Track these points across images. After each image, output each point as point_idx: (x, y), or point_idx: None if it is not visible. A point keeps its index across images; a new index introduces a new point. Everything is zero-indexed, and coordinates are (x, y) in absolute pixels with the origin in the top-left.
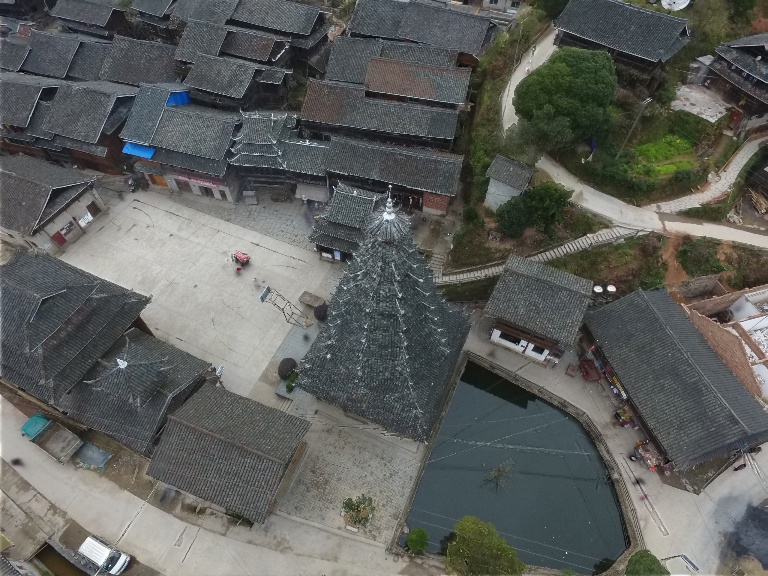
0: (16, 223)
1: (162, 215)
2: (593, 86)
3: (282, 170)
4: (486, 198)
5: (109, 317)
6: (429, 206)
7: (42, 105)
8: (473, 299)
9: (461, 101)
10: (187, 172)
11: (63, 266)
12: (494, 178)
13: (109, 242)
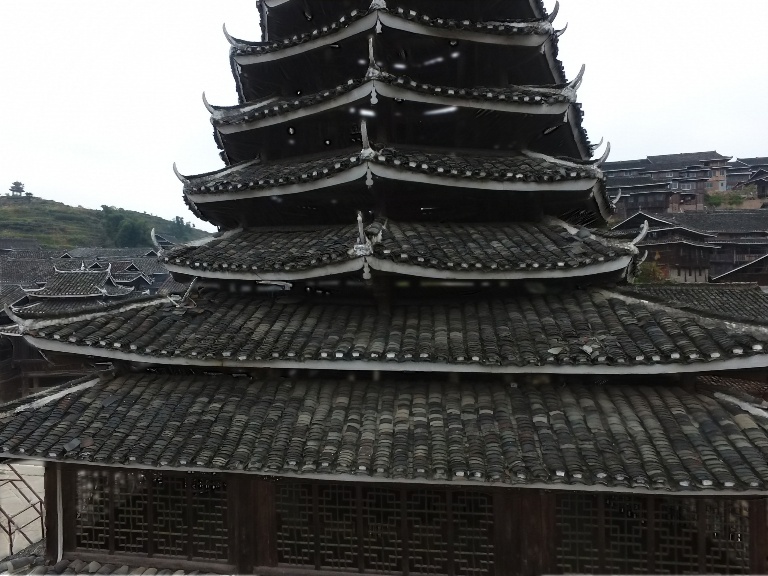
0: None
1: None
2: None
3: None
4: None
5: None
6: None
7: None
8: None
9: None
10: None
11: None
12: None
13: None
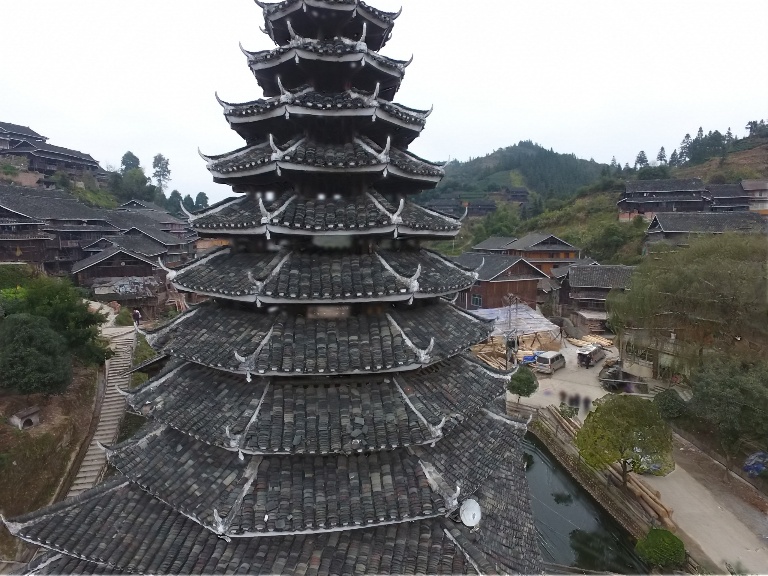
0: None
1: None
2: None
3: None
4: None
5: None
6: None
7: None
8: None
9: None
10: None
11: None
12: None
13: None
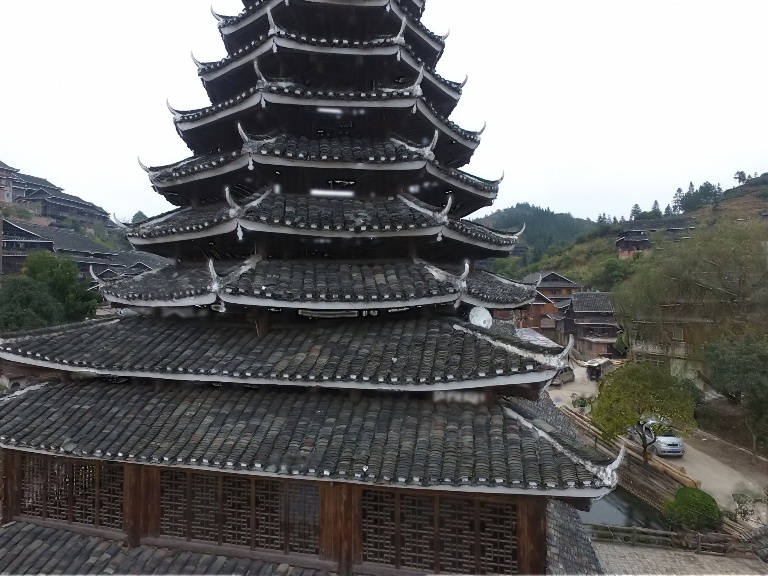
0: None
1: None
2: None
3: None
4: None
5: None
6: None
7: None
8: None
9: None
10: None
11: None
12: None
13: None
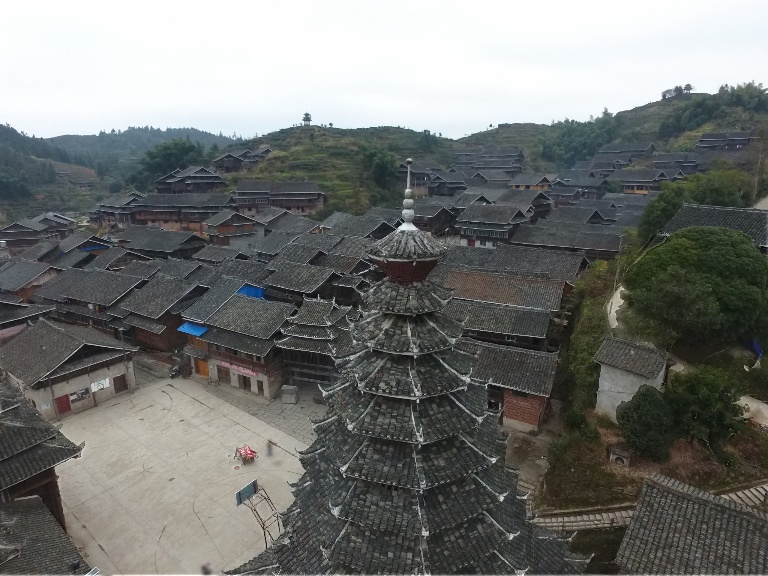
0: (29, 373)
1: (186, 401)
2: (734, 258)
3: (331, 359)
4: (598, 400)
5: (3, 455)
6: (512, 416)
7: (134, 292)
8: (592, 570)
9: (554, 308)
10: (231, 355)
11: (16, 396)
12: (606, 363)
13: (112, 418)
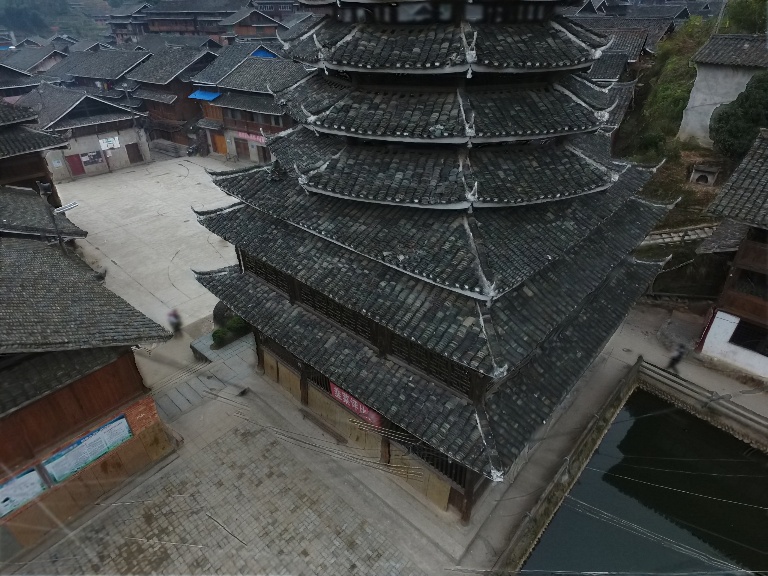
0: None
1: (203, 171)
2: None
3: None
4: (682, 122)
5: None
6: None
7: None
8: None
9: (631, 58)
10: (247, 123)
11: None
12: (707, 62)
13: (127, 180)
